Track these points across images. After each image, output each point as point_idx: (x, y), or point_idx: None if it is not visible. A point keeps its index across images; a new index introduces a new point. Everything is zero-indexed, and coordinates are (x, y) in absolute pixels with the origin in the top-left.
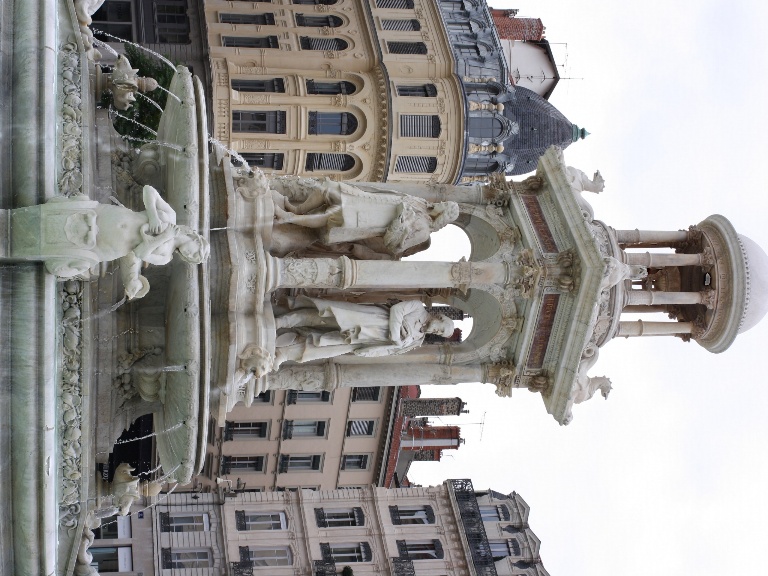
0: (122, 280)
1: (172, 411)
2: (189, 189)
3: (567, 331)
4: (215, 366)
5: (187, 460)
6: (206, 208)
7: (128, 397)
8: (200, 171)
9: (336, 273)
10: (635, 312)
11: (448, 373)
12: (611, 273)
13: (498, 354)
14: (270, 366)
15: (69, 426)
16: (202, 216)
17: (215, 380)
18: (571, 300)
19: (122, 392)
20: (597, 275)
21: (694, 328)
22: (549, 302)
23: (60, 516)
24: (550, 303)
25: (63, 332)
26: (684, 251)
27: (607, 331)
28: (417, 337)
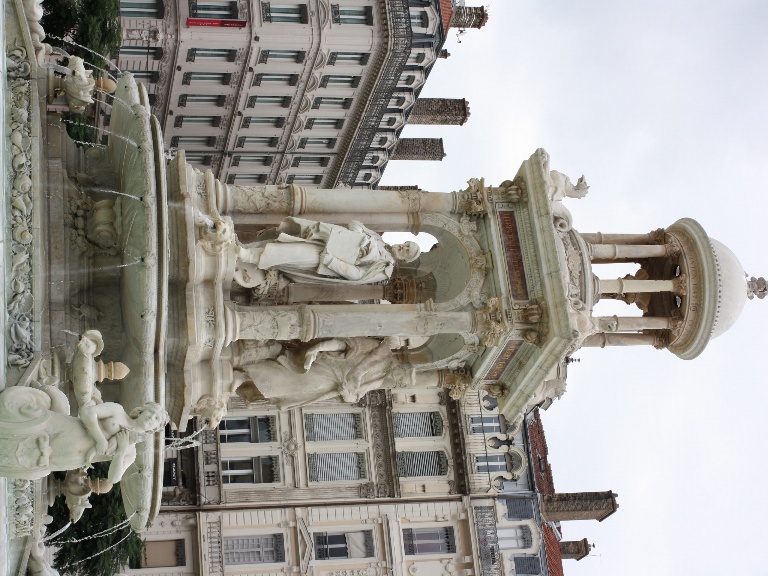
0: (69, 89)
1: (127, 180)
2: None
3: (535, 241)
4: (174, 240)
5: (147, 192)
6: (146, 97)
7: (83, 263)
8: (138, 87)
9: (284, 188)
10: (623, 340)
11: (432, 312)
12: (551, 173)
13: (480, 299)
14: (231, 230)
15: (18, 173)
16: (143, 102)
17: (176, 257)
18: (526, 210)
19: (76, 234)
20: (535, 162)
21: (674, 280)
22: (506, 221)
23: (9, 356)
24: (508, 222)
25: (12, 87)
26: None
27: (582, 269)
28: (384, 256)
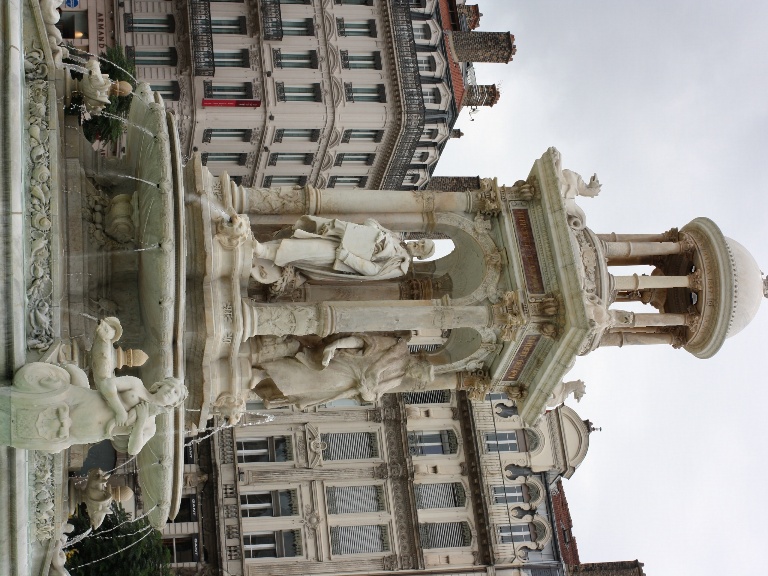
0: (86, 90)
1: (144, 171)
2: (144, 87)
3: (549, 236)
4: (191, 235)
5: (163, 179)
6: None
7: (102, 257)
8: (154, 95)
9: (299, 189)
10: (641, 338)
11: (449, 306)
12: (563, 171)
13: (496, 295)
14: (247, 225)
15: (37, 164)
16: None
17: (193, 251)
18: (539, 208)
19: (94, 228)
20: (547, 160)
21: (690, 276)
22: (520, 218)
23: (29, 341)
24: (522, 219)
25: (30, 85)
26: None
27: (597, 264)
28: (399, 252)
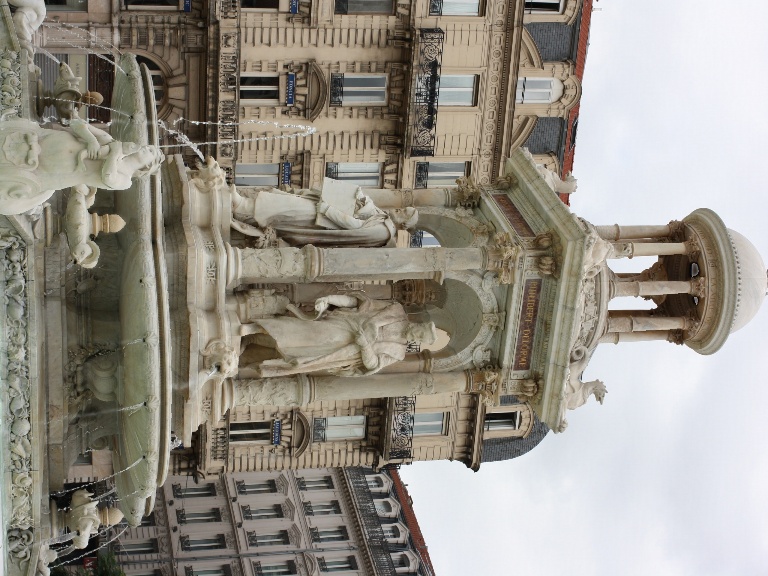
0: (57, 89)
1: None
2: None
3: (532, 201)
4: (166, 182)
5: (132, 70)
6: None
7: None
8: None
9: None
10: (651, 320)
11: None
12: None
13: None
14: None
15: None
16: None
17: (169, 189)
18: None
19: None
20: None
21: None
22: (501, 199)
23: None
24: None
25: None
26: (669, 313)
27: None
28: None
